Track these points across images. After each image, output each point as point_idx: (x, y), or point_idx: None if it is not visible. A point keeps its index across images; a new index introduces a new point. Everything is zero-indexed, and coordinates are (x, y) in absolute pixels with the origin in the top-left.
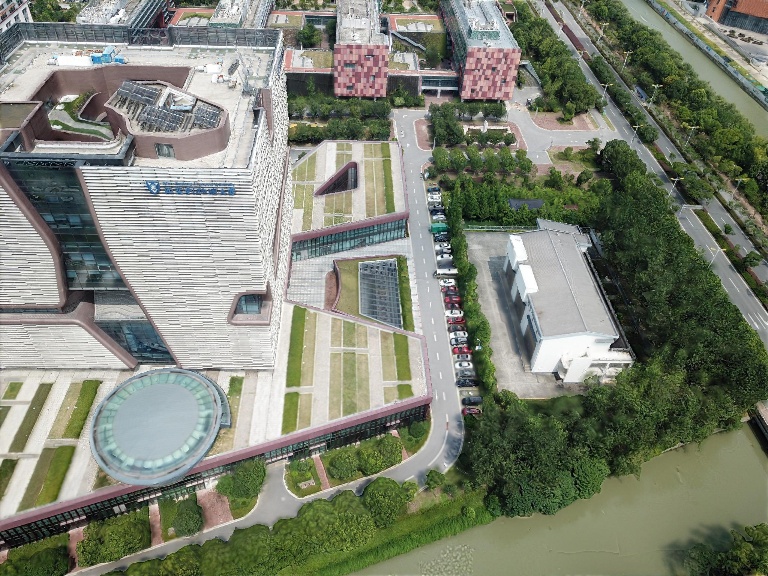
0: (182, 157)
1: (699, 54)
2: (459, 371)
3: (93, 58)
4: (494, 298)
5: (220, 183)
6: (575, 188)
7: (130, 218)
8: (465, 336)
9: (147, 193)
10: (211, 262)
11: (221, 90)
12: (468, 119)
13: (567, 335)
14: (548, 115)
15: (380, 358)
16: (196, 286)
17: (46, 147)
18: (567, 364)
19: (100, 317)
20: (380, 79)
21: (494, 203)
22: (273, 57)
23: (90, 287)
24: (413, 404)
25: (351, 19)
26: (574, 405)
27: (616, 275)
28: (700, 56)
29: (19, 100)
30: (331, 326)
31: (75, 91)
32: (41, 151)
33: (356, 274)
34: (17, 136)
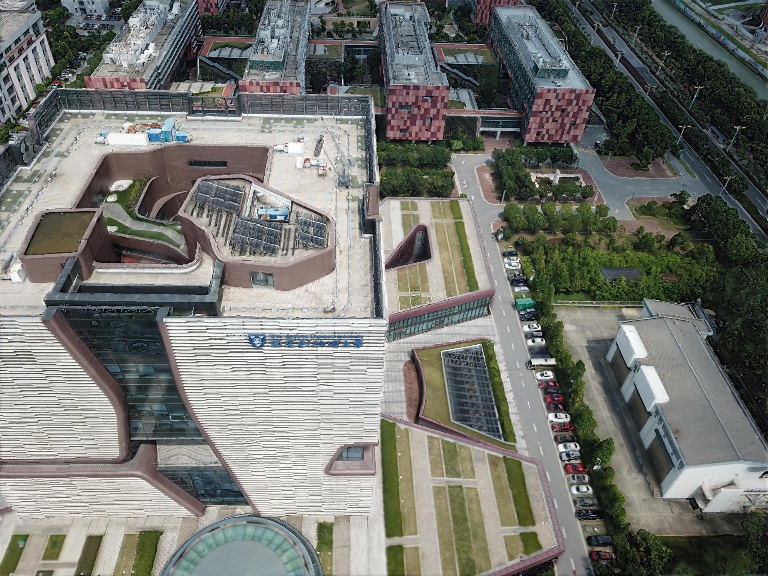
0: (283, 286)
1: (766, 85)
2: (577, 498)
3: (150, 135)
4: (601, 396)
5: (345, 335)
6: (670, 253)
7: (221, 372)
8: (577, 449)
9: (247, 346)
10: (316, 415)
11: (309, 178)
12: (534, 165)
13: (716, 464)
14: (620, 160)
15: (493, 493)
16: (292, 438)
17: (108, 272)
18: (711, 494)
19: (164, 463)
20: (437, 121)
21: (585, 274)
22: (371, 137)
23: (157, 437)
24: (542, 560)
25: (404, 55)
26: (728, 551)
27: (736, 365)
28: (767, 87)
29: (66, 197)
30: (428, 447)
31: (128, 176)
32: (102, 278)
33: (440, 367)
34: (74, 265)
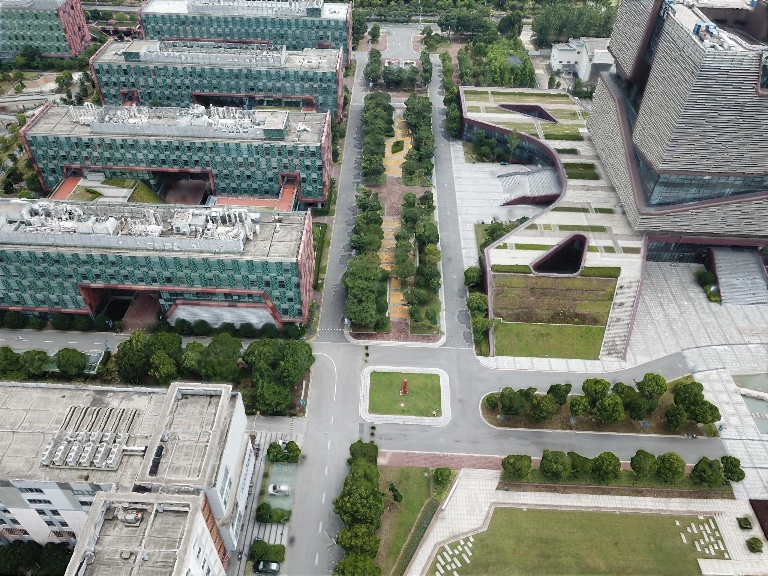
0: None
1: None
2: None
3: None
4: None
5: None
6: (489, 46)
7: None
8: None
9: None
10: None
11: (715, 2)
12: None
13: None
14: (363, 45)
15: None
16: None
17: None
18: None
19: None
20: None
21: None
22: None
23: None
24: None
25: None
26: None
27: None
28: None
29: None
30: None
31: None
32: None
33: None
34: None
